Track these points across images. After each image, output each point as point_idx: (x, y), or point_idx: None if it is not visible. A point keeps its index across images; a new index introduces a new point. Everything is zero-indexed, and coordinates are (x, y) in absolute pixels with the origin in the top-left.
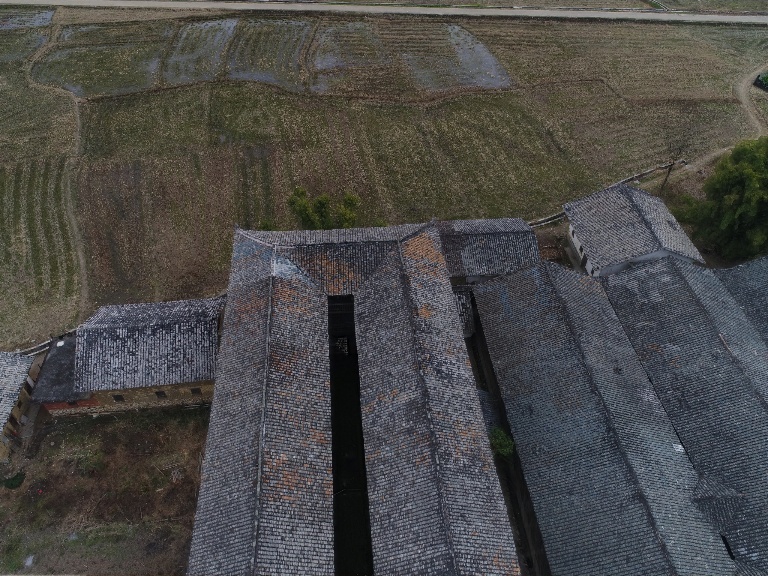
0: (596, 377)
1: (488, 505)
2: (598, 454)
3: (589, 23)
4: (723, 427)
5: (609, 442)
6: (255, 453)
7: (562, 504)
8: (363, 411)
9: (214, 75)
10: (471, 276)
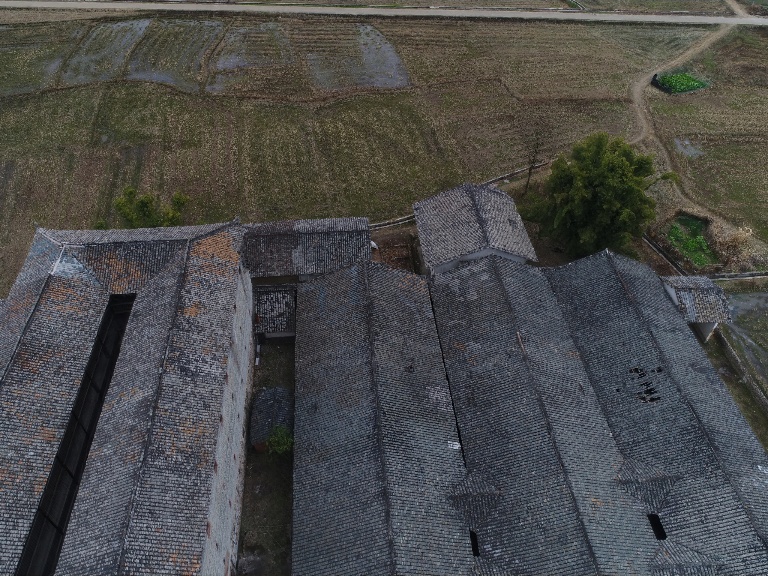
0: (379, 375)
1: (188, 502)
2: (360, 451)
3: (502, 23)
4: (500, 424)
5: (372, 439)
6: None
7: (318, 501)
8: (103, 409)
9: (112, 75)
10: (300, 275)
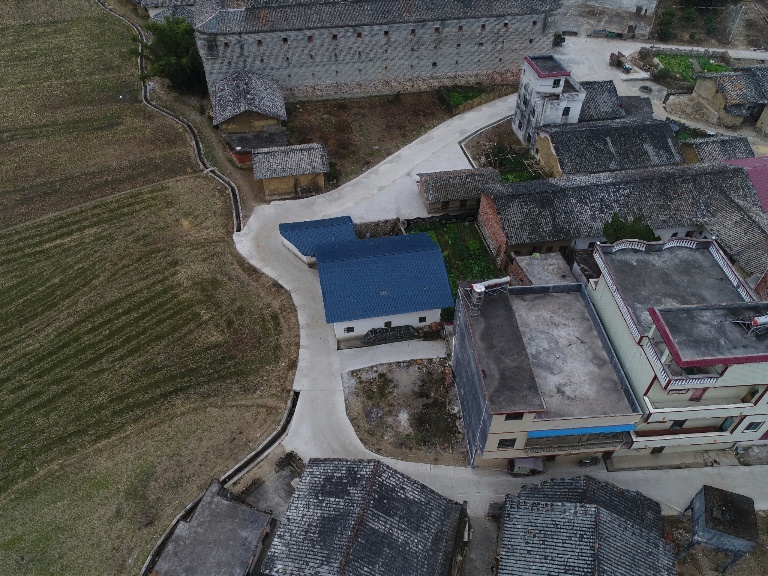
0: None
1: None
2: None
3: None
4: None
5: None
6: (352, 4)
7: None
8: (323, 1)
9: None
10: None
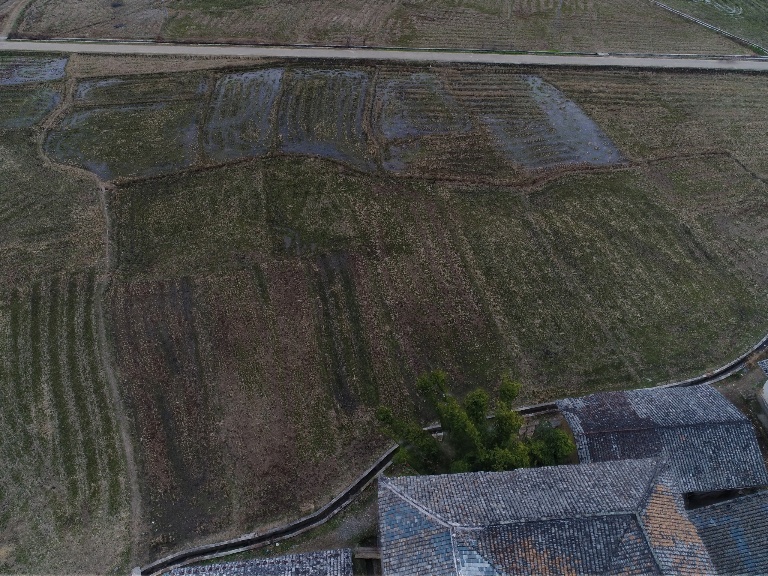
0: None
1: None
2: None
3: (690, 74)
4: None
5: None
6: None
7: None
8: None
9: (265, 148)
10: None
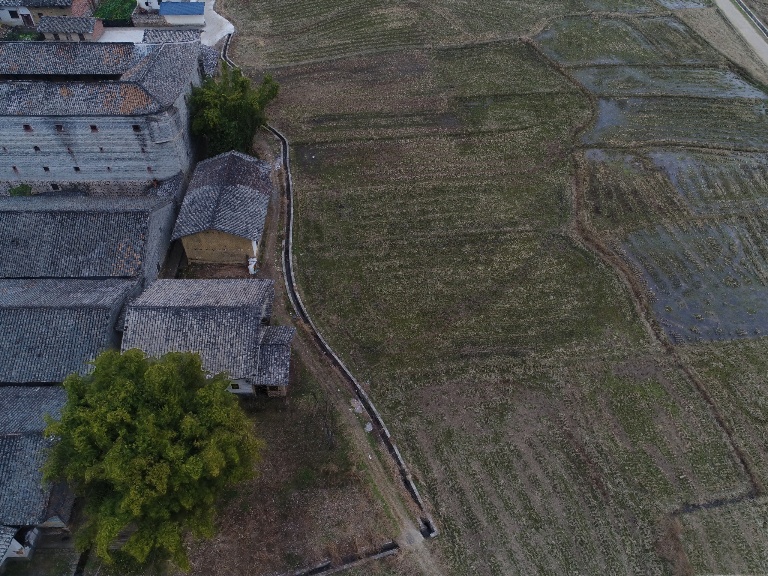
0: (8, 215)
1: None
2: None
3: None
4: None
5: None
6: None
7: None
8: None
9: (600, 91)
10: None
